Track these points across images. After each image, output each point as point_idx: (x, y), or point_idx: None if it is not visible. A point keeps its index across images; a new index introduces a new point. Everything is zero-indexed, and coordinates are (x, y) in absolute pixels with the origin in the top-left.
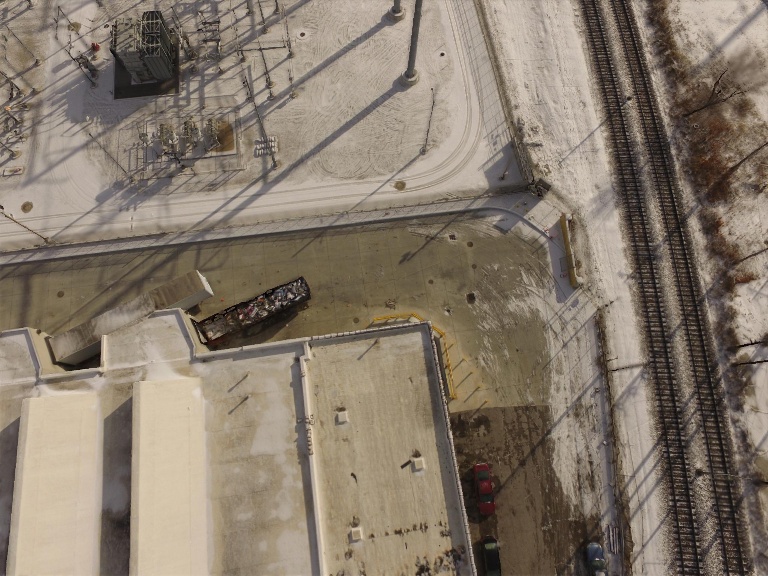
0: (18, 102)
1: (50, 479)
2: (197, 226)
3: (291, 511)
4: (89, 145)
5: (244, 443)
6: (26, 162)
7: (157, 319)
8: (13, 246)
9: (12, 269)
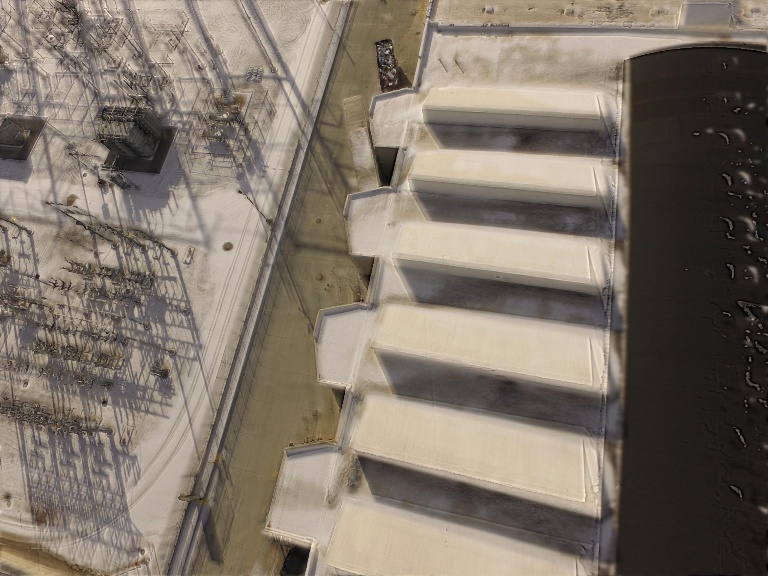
0: (123, 249)
1: (474, 171)
2: (301, 126)
3: (543, 44)
4: (193, 195)
5: (487, 66)
6: (185, 245)
7: (375, 113)
8: (259, 259)
9: (280, 256)
